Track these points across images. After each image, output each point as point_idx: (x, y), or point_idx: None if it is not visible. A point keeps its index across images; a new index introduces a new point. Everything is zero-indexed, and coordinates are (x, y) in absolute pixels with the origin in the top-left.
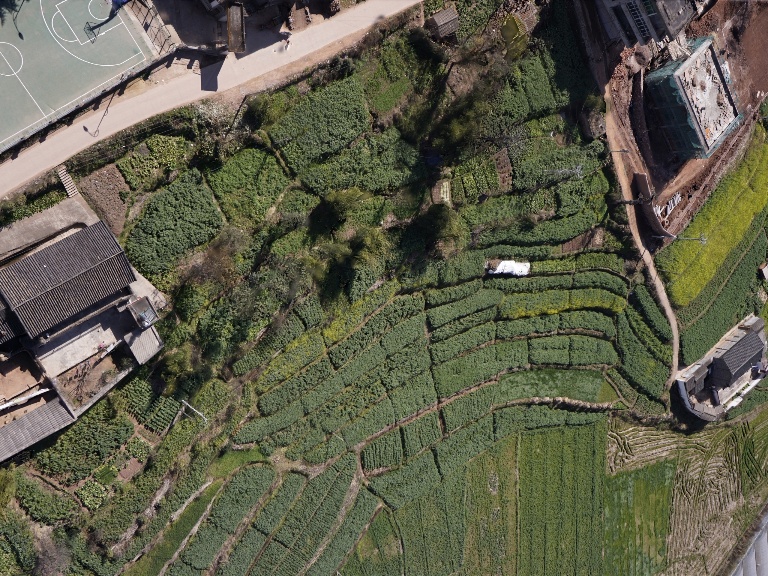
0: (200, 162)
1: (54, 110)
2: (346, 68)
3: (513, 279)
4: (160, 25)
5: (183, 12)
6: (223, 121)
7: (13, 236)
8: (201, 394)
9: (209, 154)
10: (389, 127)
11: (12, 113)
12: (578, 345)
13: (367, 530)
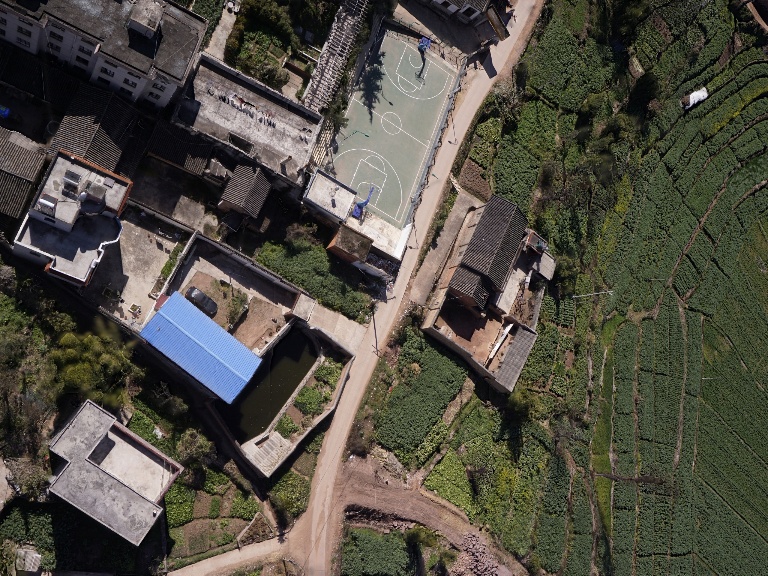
0: (505, 130)
1: (429, 140)
2: (550, 13)
3: (701, 105)
4: (451, 50)
5: (455, 34)
6: (510, 92)
7: (447, 235)
8: (576, 289)
9: (512, 120)
10: (586, 40)
11: (412, 155)
12: (763, 130)
13: (703, 340)
